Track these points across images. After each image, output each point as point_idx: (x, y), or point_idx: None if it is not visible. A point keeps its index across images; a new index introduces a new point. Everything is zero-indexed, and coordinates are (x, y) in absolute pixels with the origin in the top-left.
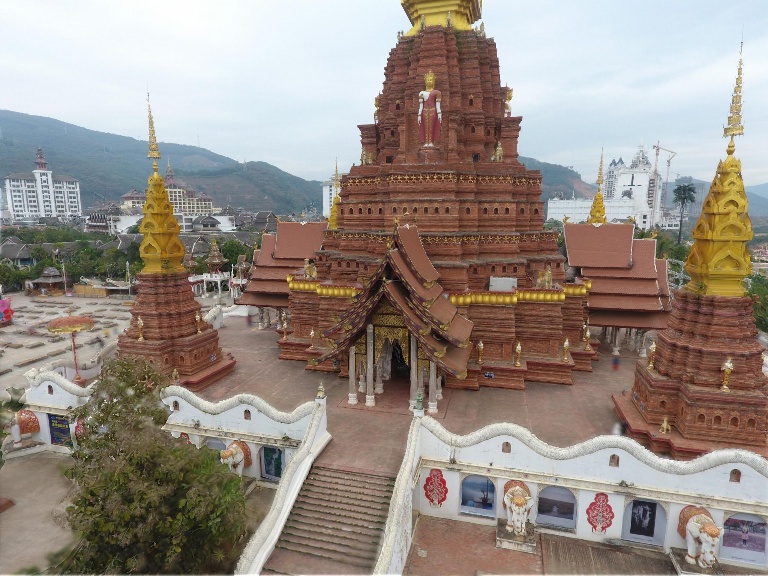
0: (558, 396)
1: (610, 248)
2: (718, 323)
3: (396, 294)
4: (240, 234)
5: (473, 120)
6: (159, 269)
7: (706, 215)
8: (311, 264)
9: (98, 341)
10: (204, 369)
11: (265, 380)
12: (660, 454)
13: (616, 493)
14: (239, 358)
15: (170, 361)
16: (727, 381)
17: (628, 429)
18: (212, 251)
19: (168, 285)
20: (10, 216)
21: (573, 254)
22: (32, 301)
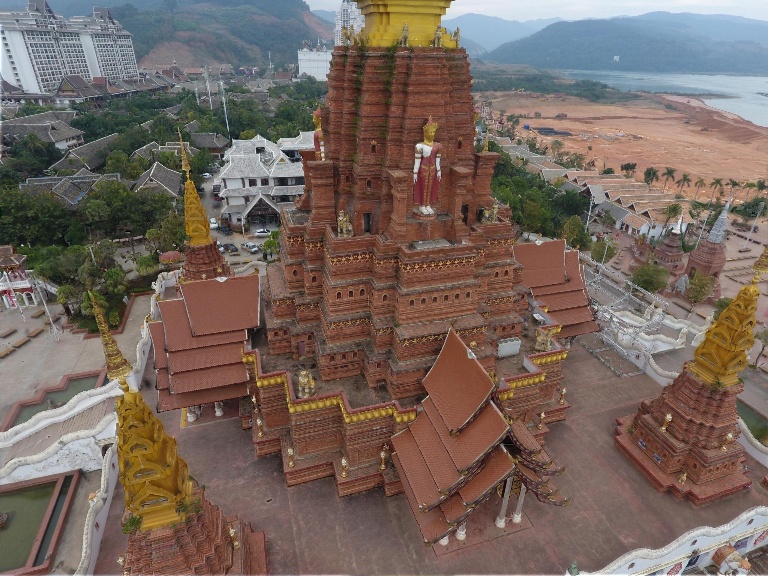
0: (571, 442)
1: (550, 265)
2: (726, 407)
3: None
4: None
5: None
6: (174, 517)
7: (729, 329)
8: (307, 374)
9: None
10: (250, 575)
11: (318, 542)
12: (682, 499)
13: (689, 558)
14: (238, 507)
15: None
16: (726, 444)
17: (653, 480)
18: None
19: (191, 526)
20: None
21: (523, 275)
22: None
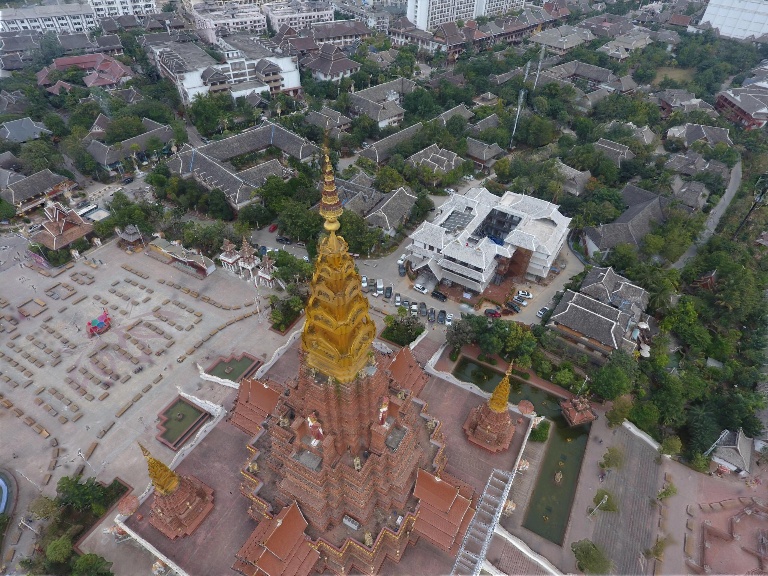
0: None
1: (441, 496)
2: None
3: (261, 575)
4: (289, 136)
5: (347, 432)
6: (163, 492)
7: None
8: (253, 463)
9: (161, 379)
10: (196, 518)
11: (226, 526)
12: None
13: None
14: (221, 486)
15: (177, 521)
16: None
17: None
18: (243, 245)
19: None
20: (91, 10)
21: (418, 488)
22: (122, 267)
